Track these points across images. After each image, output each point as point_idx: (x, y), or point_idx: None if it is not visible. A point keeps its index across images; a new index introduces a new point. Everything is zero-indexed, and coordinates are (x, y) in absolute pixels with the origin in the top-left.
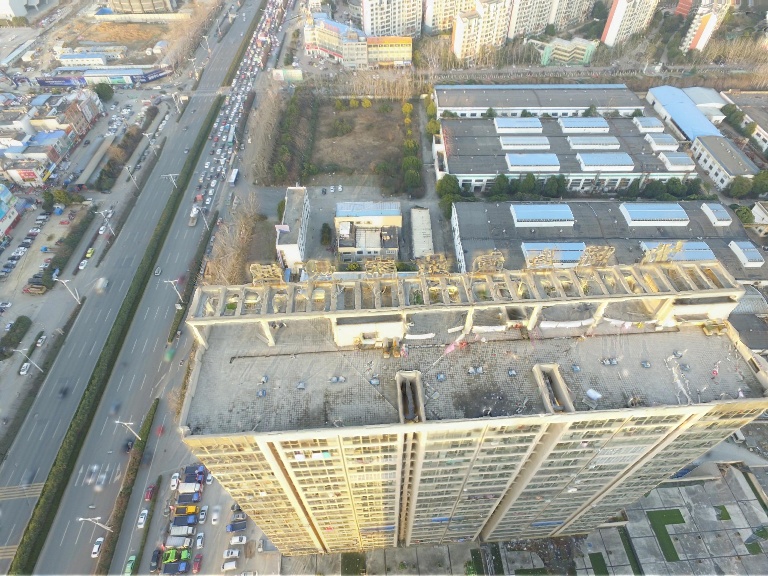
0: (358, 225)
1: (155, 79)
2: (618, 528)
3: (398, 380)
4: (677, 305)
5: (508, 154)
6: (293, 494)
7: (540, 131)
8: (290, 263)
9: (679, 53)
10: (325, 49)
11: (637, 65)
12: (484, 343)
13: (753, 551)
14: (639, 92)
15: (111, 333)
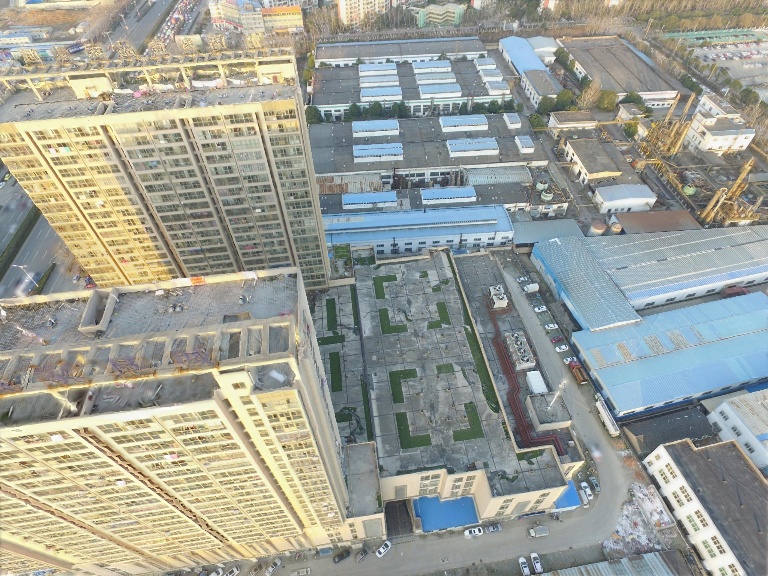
0: None
1: (76, 52)
2: (350, 286)
3: (100, 104)
4: (259, 65)
5: (362, 89)
6: (73, 204)
7: (395, 73)
8: None
9: (534, 12)
10: (229, 22)
11: (497, 23)
12: (160, 94)
13: (435, 291)
14: (492, 43)
15: (20, 225)
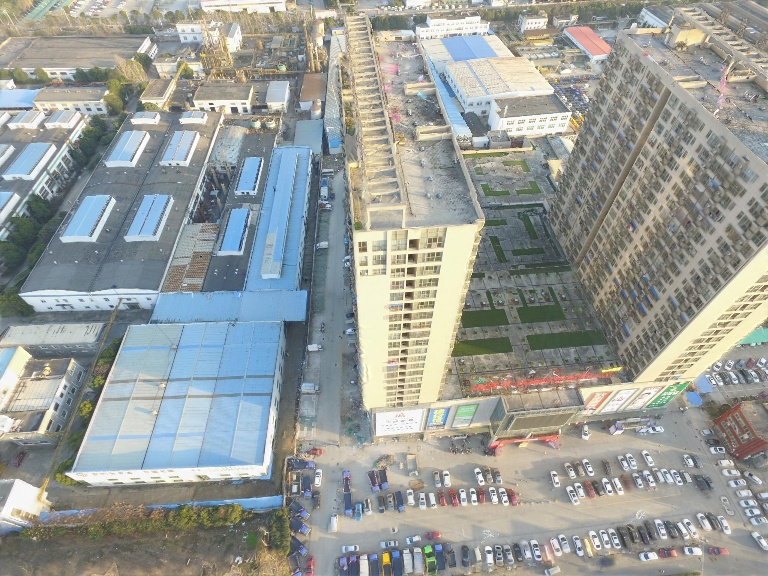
0: (1, 408)
1: None
2: None
3: (424, 134)
4: None
5: None
6: None
7: None
8: (34, 508)
9: None
10: None
11: None
12: None
13: None
14: None
15: None
